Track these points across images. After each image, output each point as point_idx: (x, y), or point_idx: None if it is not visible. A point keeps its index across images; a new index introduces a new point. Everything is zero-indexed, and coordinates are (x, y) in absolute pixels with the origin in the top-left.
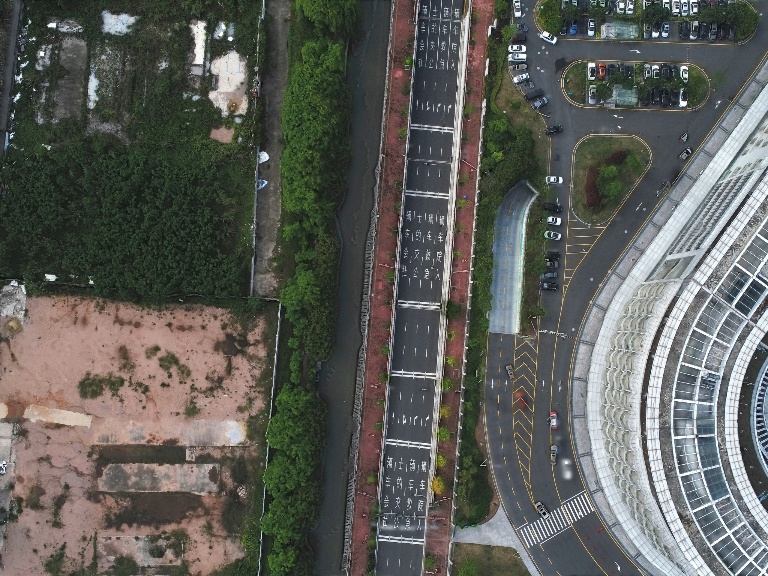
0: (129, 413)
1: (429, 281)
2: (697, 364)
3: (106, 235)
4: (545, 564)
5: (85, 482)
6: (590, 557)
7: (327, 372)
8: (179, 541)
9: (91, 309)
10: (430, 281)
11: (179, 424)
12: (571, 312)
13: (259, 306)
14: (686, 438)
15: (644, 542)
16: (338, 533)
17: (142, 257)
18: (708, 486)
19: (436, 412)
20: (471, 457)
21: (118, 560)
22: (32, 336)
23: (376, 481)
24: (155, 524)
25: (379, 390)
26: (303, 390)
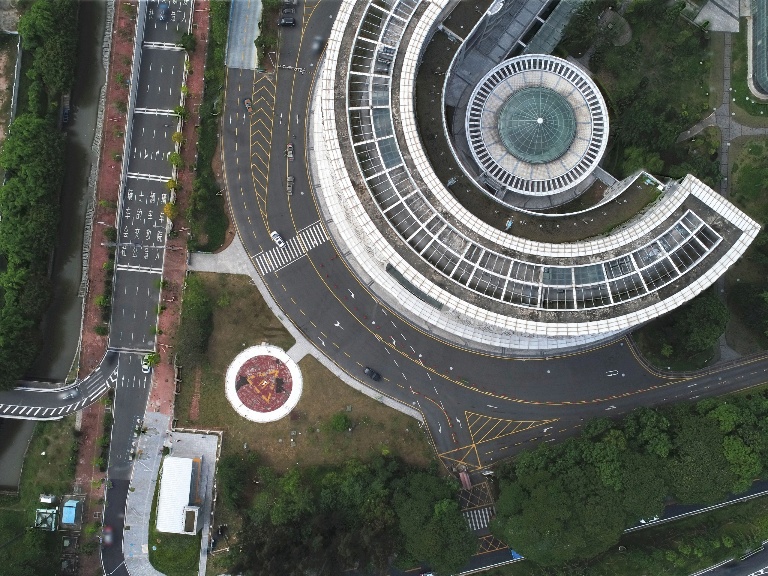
0: None
1: (175, 23)
2: (374, 38)
3: None
4: (279, 291)
5: None
6: (324, 284)
7: (74, 111)
8: None
9: None
10: (176, 23)
11: None
12: (310, 48)
13: None
14: (361, 109)
15: (367, 259)
16: (76, 261)
17: None
18: (382, 155)
19: (177, 147)
20: (200, 179)
21: None
22: None
23: (115, 211)
24: None
25: (119, 123)
26: (37, 115)
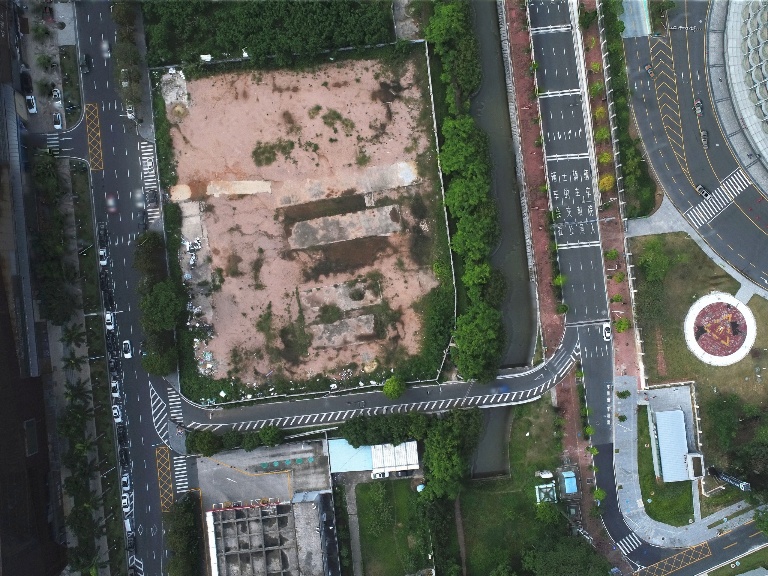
0: (304, 172)
1: (556, 6)
2: None
3: (254, 2)
4: (716, 241)
5: (277, 243)
6: (756, 227)
7: (477, 108)
8: (375, 281)
9: (249, 83)
10: (557, 6)
11: (353, 174)
12: (695, 6)
13: (408, 46)
14: None
15: None
16: (520, 248)
17: (291, 18)
18: None
19: (587, 123)
20: (633, 147)
21: (323, 309)
22: (199, 117)
23: (545, 195)
24: (350, 270)
25: (532, 110)
26: None
